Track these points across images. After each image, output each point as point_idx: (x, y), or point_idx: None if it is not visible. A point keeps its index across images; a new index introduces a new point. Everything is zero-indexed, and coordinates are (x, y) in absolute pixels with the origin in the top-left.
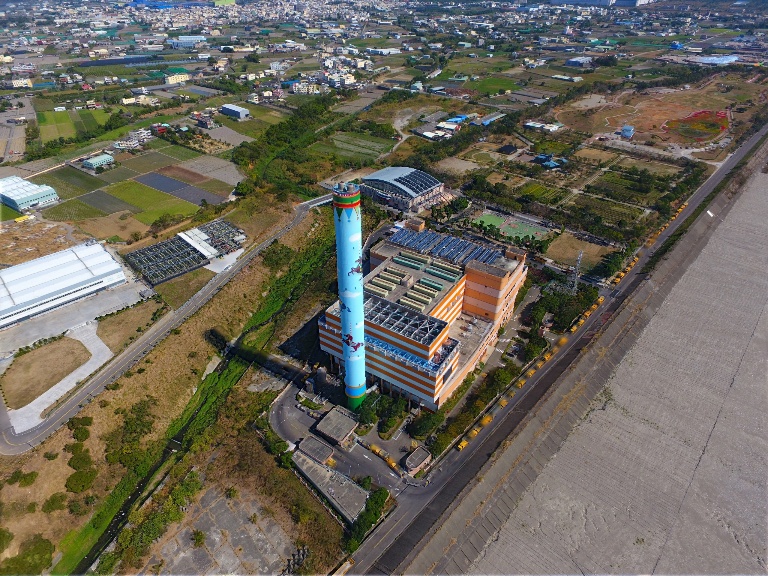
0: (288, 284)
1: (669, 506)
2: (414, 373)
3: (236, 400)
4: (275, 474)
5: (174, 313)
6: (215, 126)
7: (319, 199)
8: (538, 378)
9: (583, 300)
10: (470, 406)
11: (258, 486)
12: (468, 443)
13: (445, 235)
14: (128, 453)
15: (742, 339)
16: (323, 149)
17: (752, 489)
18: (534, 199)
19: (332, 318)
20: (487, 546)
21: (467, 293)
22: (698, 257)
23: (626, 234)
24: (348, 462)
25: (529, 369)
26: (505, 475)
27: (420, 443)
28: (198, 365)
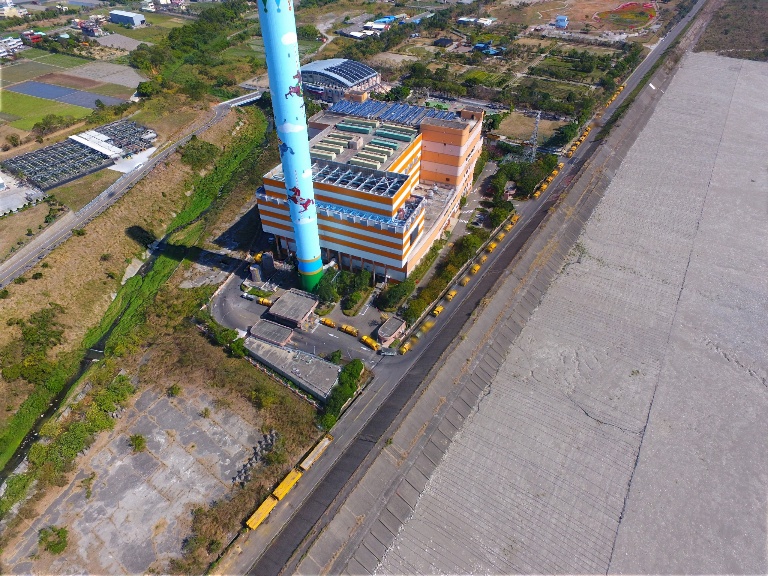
0: (215, 182)
1: (658, 338)
2: (377, 234)
3: (167, 298)
4: (226, 365)
5: (74, 215)
6: (104, 34)
7: (241, 98)
8: (508, 242)
9: (543, 166)
10: (440, 274)
11: (206, 380)
12: (444, 308)
13: (391, 104)
14: (31, 365)
15: (700, 189)
16: (239, 53)
17: (733, 313)
18: (478, 82)
19: (272, 184)
20: (479, 401)
21: (424, 157)
22: (647, 124)
23: (576, 107)
24: (311, 343)
25: (497, 234)
26: (488, 331)
27: (391, 315)
28: (114, 269)
